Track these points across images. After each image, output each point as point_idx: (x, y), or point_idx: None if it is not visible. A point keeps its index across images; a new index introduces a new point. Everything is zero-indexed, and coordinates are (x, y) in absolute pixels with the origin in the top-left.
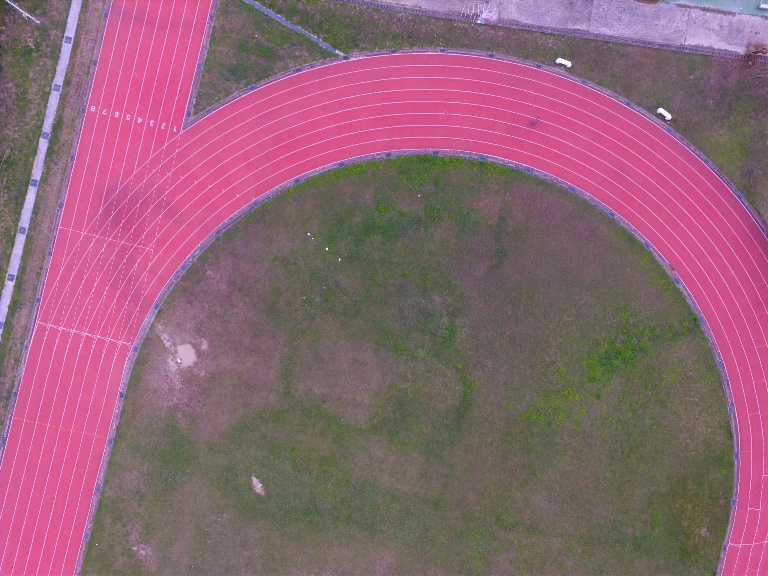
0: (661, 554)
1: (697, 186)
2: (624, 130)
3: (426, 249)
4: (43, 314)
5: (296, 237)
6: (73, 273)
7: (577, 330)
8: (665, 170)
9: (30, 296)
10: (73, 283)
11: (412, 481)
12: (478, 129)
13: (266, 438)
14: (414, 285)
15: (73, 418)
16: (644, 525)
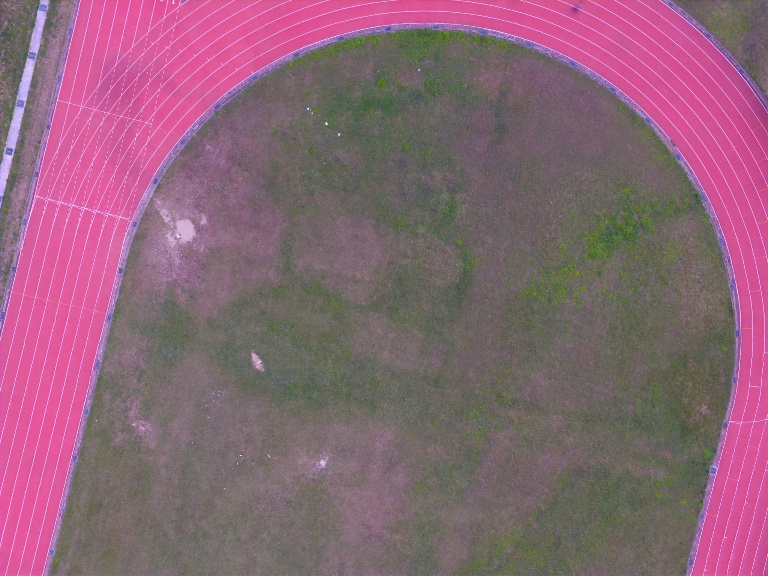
0: (662, 431)
1: (699, 61)
2: (625, 4)
3: (426, 124)
4: (42, 188)
5: (295, 112)
6: (71, 147)
7: (578, 206)
8: (666, 45)
9: (28, 170)
10: (72, 157)
11: (412, 358)
12: (478, 3)
13: (266, 314)
14: (414, 161)
15: (72, 293)
16: (645, 402)
